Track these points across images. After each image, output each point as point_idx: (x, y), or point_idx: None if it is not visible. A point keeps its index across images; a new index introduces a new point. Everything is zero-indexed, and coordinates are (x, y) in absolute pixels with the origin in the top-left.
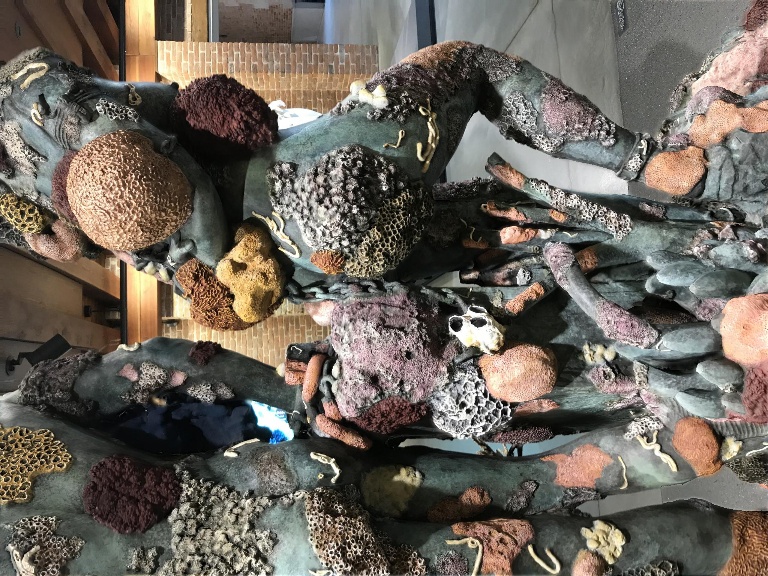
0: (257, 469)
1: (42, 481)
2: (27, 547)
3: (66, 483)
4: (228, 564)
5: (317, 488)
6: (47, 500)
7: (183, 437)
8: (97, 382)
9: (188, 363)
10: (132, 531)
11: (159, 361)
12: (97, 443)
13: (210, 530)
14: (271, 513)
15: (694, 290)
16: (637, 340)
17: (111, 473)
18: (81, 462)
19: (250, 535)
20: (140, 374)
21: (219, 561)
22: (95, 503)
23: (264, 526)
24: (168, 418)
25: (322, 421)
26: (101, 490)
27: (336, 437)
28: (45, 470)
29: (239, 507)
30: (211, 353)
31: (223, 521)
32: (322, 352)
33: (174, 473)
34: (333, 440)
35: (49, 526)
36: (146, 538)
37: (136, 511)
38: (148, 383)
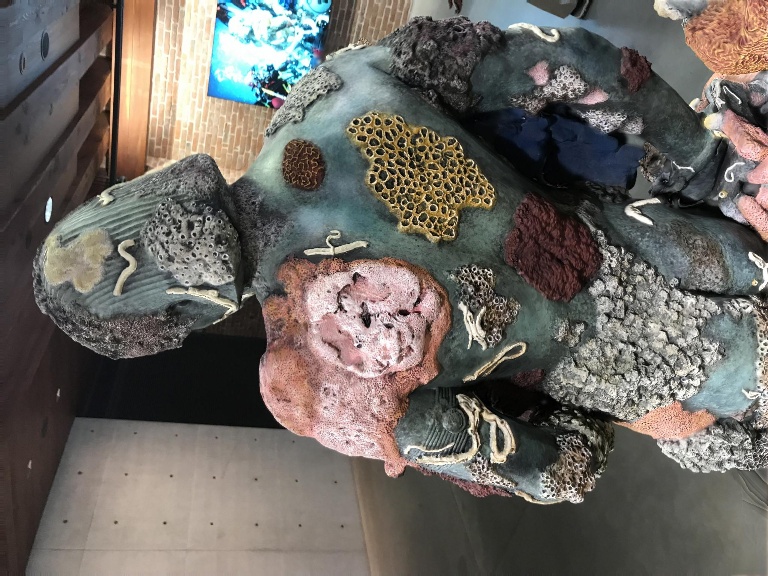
0: (690, 256)
1: (466, 216)
2: (478, 308)
3: (490, 224)
4: (671, 368)
5: (756, 299)
6: (470, 241)
7: (547, 158)
8: (499, 75)
9: (617, 83)
10: (559, 299)
11: (583, 69)
12: (500, 166)
13: (640, 318)
14: (721, 324)
15: None
16: None
17: (539, 223)
18: (504, 199)
19: (697, 342)
20: (551, 79)
21: (663, 362)
22: (518, 255)
23: (713, 337)
24: (547, 136)
25: (756, 209)
26: (527, 242)
27: (759, 230)
28: (470, 203)
29: (675, 301)
30: (646, 76)
31: (657, 312)
32: (754, 105)
33: (590, 231)
34: (752, 231)
35: (489, 282)
36: (571, 309)
37: (564, 277)
38: (554, 92)
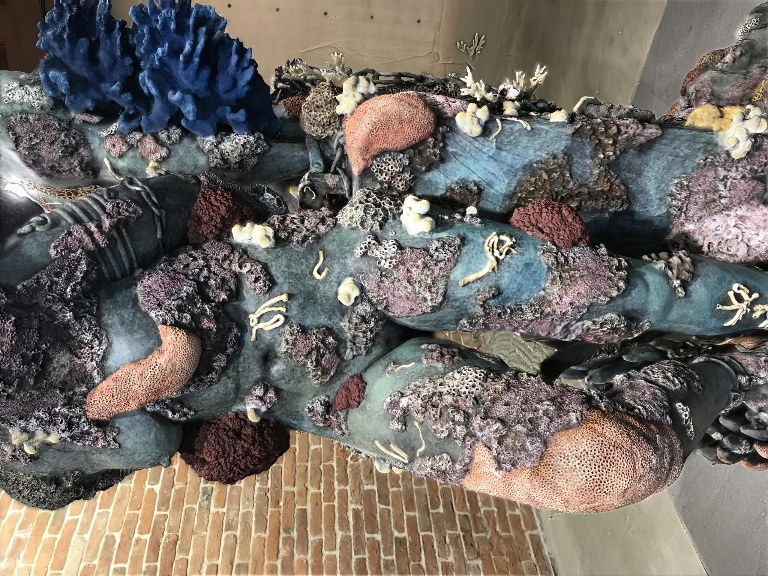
0: None
1: None
2: None
3: None
4: None
5: None
6: None
7: None
8: None
9: None
10: None
11: None
12: None
13: None
14: None
15: None
16: None
17: None
18: None
19: None
20: None
21: None
22: None
23: None
24: None
25: None
26: None
27: None
28: None
29: None
30: None
31: None
32: None
33: None
34: None
35: None
36: None
37: None
38: None
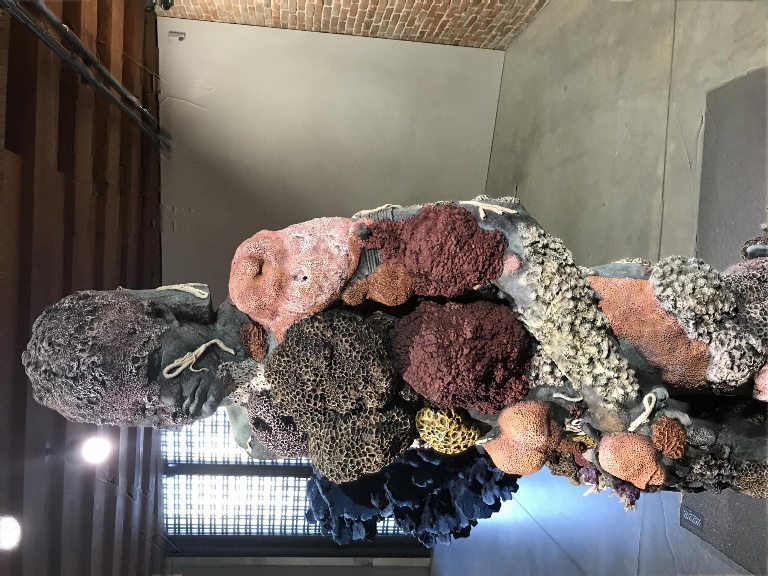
0: None
1: None
2: None
3: None
4: None
5: None
6: None
7: None
8: None
9: None
10: None
11: None
12: None
13: None
14: None
15: (764, 225)
16: (764, 259)
17: None
18: None
19: None
20: None
21: None
22: None
23: None
24: None
25: None
26: None
27: None
28: None
29: None
30: None
31: None
32: None
33: None
34: None
35: None
36: None
37: None
38: None
